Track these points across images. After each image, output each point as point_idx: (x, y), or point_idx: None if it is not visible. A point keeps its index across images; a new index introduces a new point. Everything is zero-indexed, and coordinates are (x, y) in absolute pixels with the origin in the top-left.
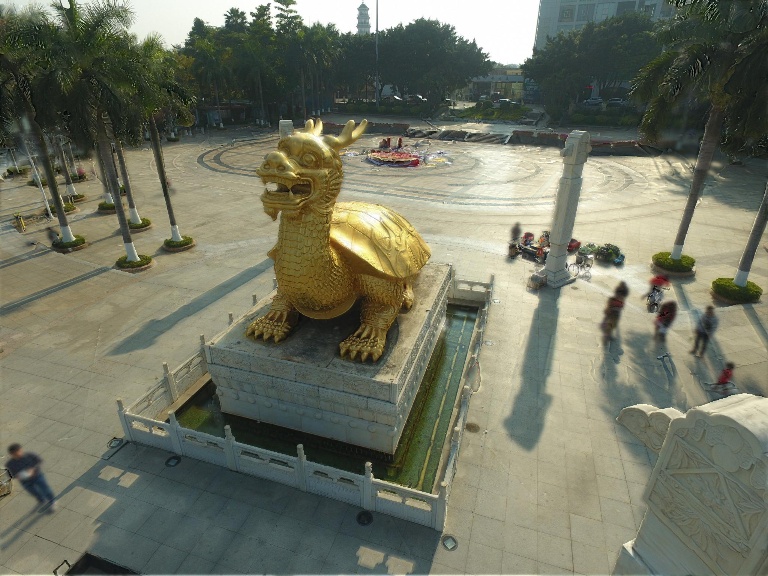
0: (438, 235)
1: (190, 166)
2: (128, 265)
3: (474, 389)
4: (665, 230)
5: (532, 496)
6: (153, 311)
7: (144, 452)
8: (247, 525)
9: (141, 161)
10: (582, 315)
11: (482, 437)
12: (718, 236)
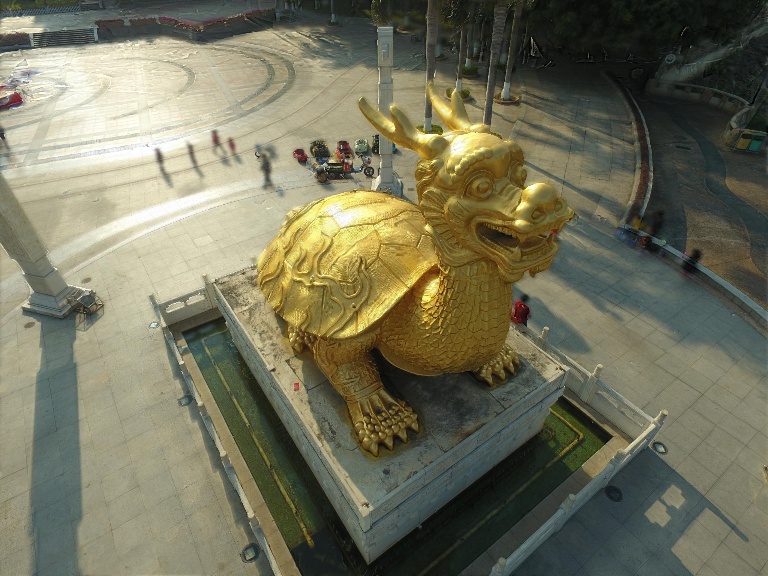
0: (209, 190)
1: None
2: None
3: (526, 326)
4: None
5: (631, 371)
6: None
7: None
8: None
9: None
10: None
11: (557, 358)
12: (413, 98)
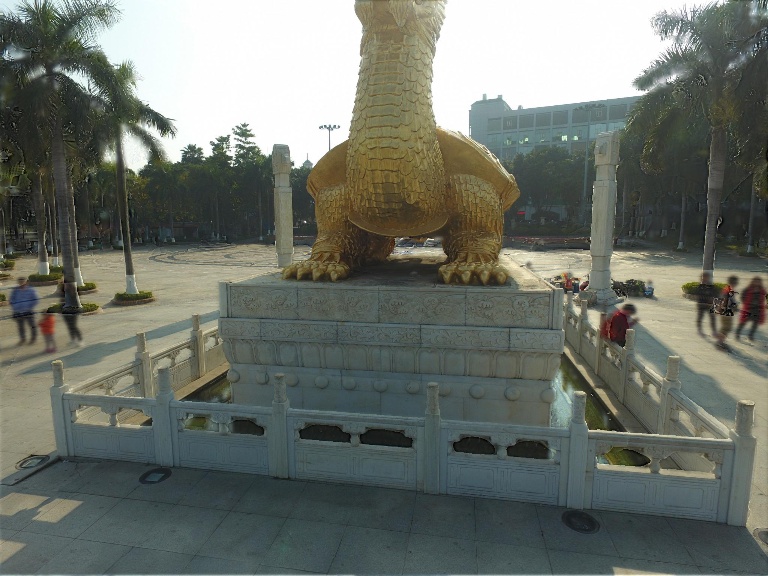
0: None
1: (141, 261)
2: (65, 310)
3: None
4: (668, 279)
5: None
6: (103, 336)
7: (93, 468)
8: (345, 557)
9: (83, 260)
10: (662, 318)
11: None
12: (722, 281)
